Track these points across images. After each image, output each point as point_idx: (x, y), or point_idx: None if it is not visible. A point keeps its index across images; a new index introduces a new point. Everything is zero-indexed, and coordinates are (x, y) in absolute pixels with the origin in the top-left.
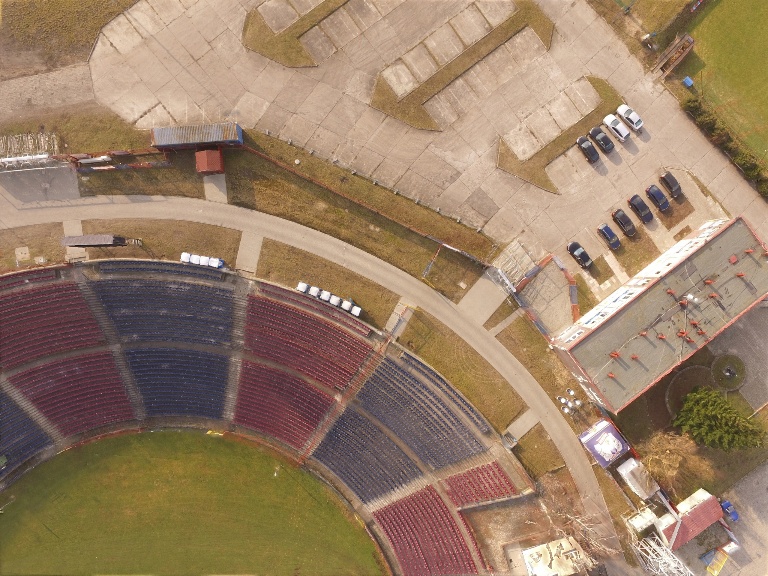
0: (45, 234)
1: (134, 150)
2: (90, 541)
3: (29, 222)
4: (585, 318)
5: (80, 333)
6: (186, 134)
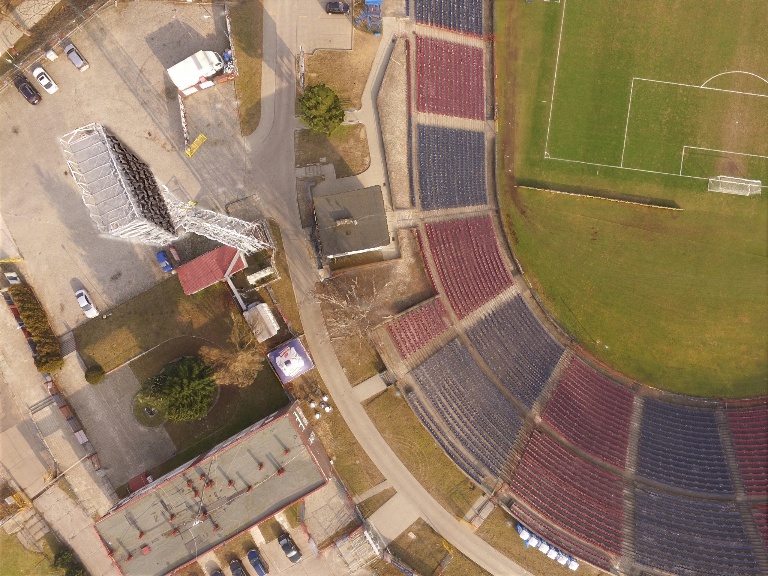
0: None
1: None
2: None
3: None
4: None
5: None
6: None
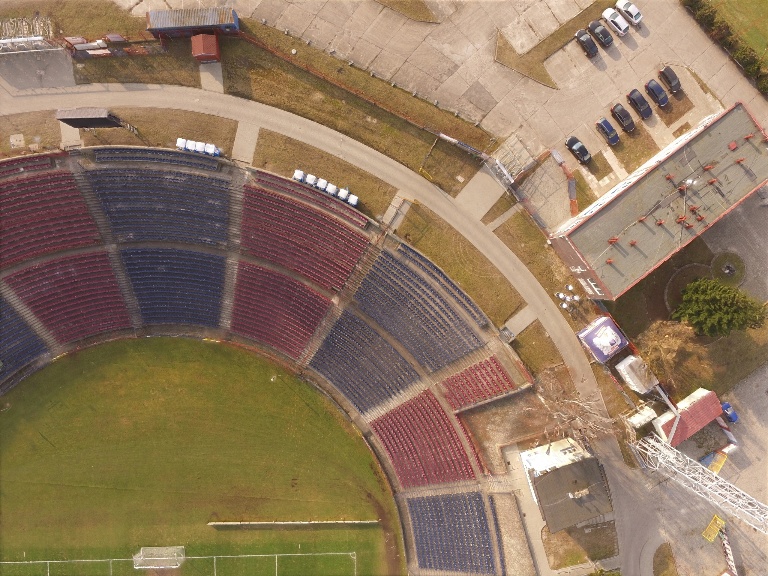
0: (40, 121)
1: (130, 37)
2: (86, 450)
3: (24, 109)
4: (583, 212)
5: (76, 230)
6: (182, 17)
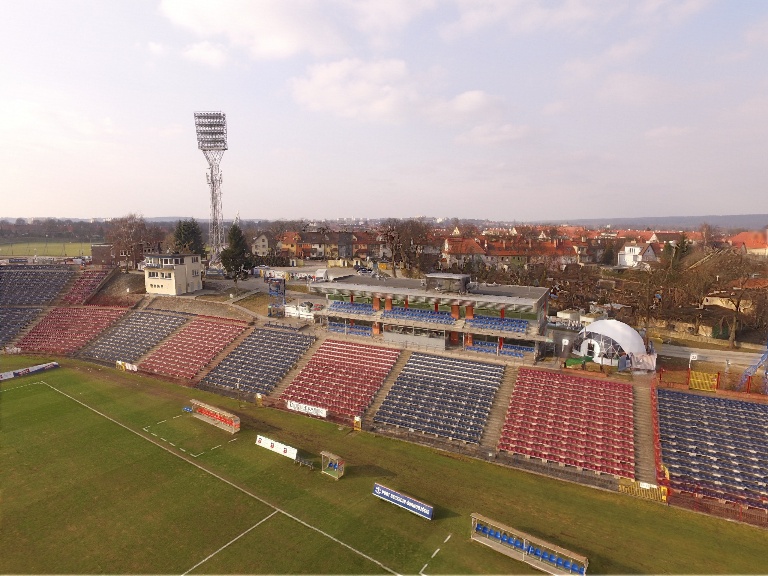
0: None
1: None
2: None
3: None
4: None
5: None
6: None
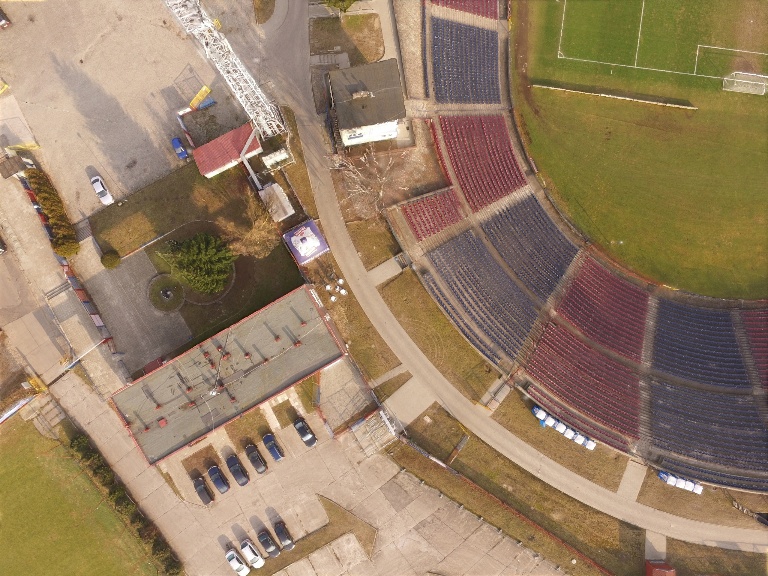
0: None
1: None
2: None
3: None
4: None
5: None
6: None
